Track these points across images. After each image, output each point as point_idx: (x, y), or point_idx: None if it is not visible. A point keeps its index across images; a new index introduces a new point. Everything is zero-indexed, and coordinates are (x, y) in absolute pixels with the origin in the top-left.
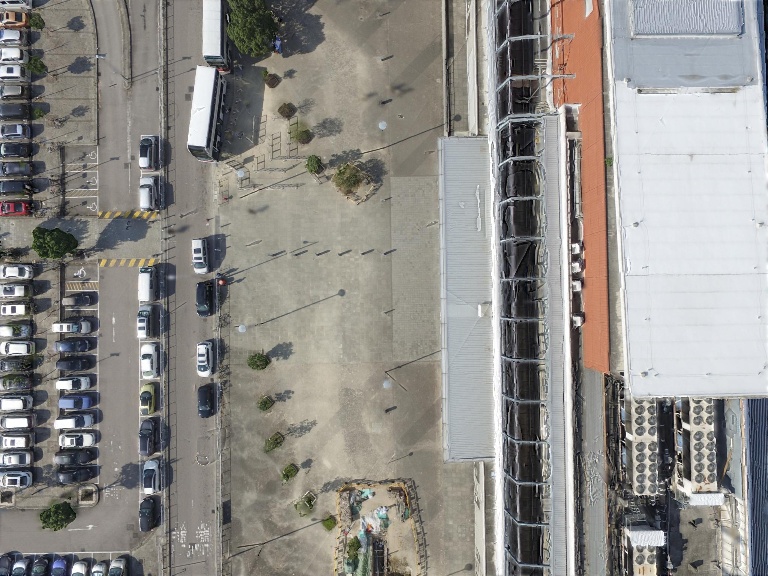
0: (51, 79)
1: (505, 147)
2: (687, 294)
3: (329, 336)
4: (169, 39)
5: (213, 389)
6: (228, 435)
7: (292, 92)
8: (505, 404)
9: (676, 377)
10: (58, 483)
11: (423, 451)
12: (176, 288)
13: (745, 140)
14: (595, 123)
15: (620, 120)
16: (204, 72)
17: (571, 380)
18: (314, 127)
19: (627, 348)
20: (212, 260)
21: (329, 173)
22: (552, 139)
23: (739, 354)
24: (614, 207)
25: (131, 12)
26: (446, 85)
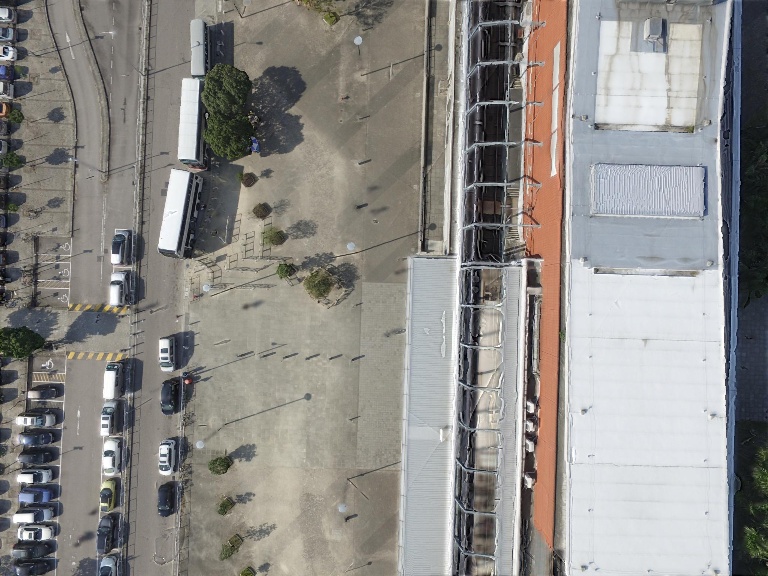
0: (29, 169)
1: (470, 284)
2: (633, 486)
3: (293, 440)
4: (148, 133)
5: (174, 487)
6: (187, 534)
7: (268, 192)
8: (457, 547)
9: (617, 573)
10: (15, 575)
11: (382, 561)
12: (142, 384)
13: (701, 327)
14: (553, 289)
15: (574, 301)
16: (178, 176)
17: (520, 541)
18: (288, 228)
19: (569, 537)
20: (180, 357)
21: (301, 275)
22: (513, 290)
23: (683, 551)
24: (564, 390)
25: (111, 105)
26: (422, 193)
